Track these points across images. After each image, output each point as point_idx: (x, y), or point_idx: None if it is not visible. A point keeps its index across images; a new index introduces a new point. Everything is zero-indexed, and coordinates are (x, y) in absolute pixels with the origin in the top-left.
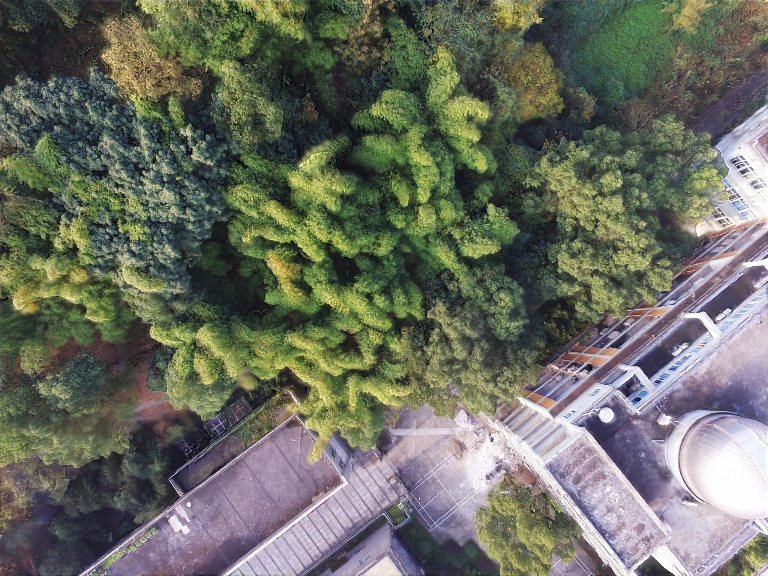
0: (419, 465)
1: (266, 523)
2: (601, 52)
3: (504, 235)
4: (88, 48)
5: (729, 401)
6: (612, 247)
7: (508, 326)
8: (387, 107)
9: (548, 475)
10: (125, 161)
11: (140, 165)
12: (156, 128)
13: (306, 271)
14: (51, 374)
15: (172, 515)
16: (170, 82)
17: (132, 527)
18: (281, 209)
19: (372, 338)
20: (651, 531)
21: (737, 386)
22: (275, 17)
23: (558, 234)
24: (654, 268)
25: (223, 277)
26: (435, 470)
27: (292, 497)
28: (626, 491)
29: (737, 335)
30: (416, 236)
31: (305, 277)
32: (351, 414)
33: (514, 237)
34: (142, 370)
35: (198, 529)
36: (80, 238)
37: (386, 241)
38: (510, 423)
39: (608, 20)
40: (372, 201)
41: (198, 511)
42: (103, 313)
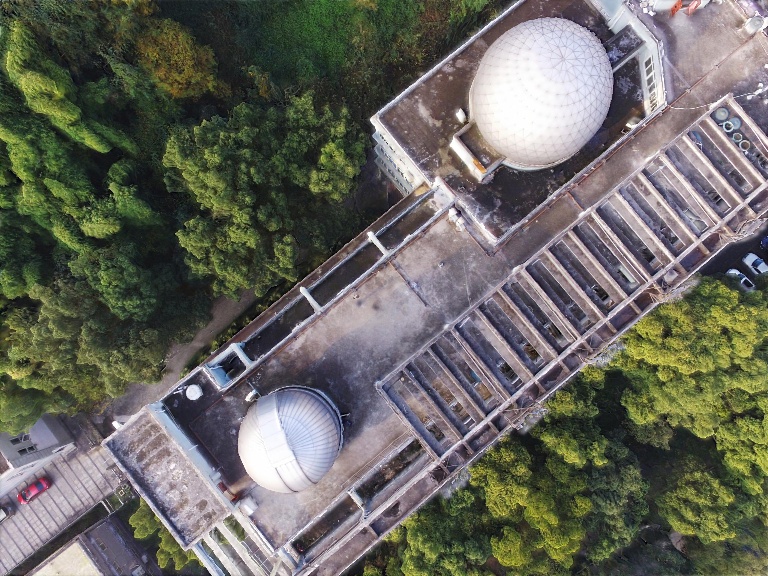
0: None
1: None
2: (294, 31)
3: (131, 214)
4: None
5: (323, 376)
6: (229, 224)
7: (121, 305)
8: None
9: None
10: None
11: None
12: None
13: None
14: None
15: None
16: None
17: None
18: None
19: None
20: (213, 507)
21: (331, 361)
22: None
23: None
24: (278, 245)
25: None
26: None
27: None
28: (190, 468)
29: (333, 310)
30: (36, 216)
31: None
32: None
33: (160, 217)
34: None
35: None
36: None
37: None
38: None
39: None
40: None
41: None
42: None
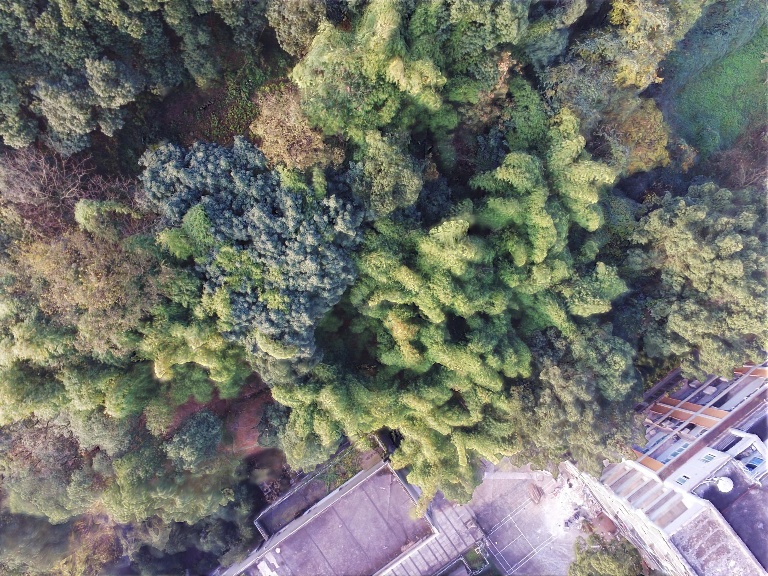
0: (496, 509)
1: (355, 571)
2: (696, 100)
3: (612, 293)
4: (208, 103)
5: None
6: (726, 310)
7: (619, 388)
8: (514, 171)
9: (672, 548)
10: (269, 231)
11: (283, 235)
12: (300, 198)
13: (423, 332)
14: (177, 435)
15: (261, 561)
16: (317, 153)
17: (212, 566)
18: (413, 276)
19: (481, 396)
20: None
21: None
22: (420, 88)
23: (659, 289)
24: (766, 331)
25: (333, 332)
26: (512, 515)
27: (381, 546)
28: (751, 566)
29: None
30: None
31: (422, 338)
32: (453, 470)
33: None
34: (240, 418)
35: (287, 575)
36: (223, 308)
37: (500, 301)
38: (603, 477)
39: (705, 69)
40: (487, 260)
41: (287, 557)
42: (226, 373)
